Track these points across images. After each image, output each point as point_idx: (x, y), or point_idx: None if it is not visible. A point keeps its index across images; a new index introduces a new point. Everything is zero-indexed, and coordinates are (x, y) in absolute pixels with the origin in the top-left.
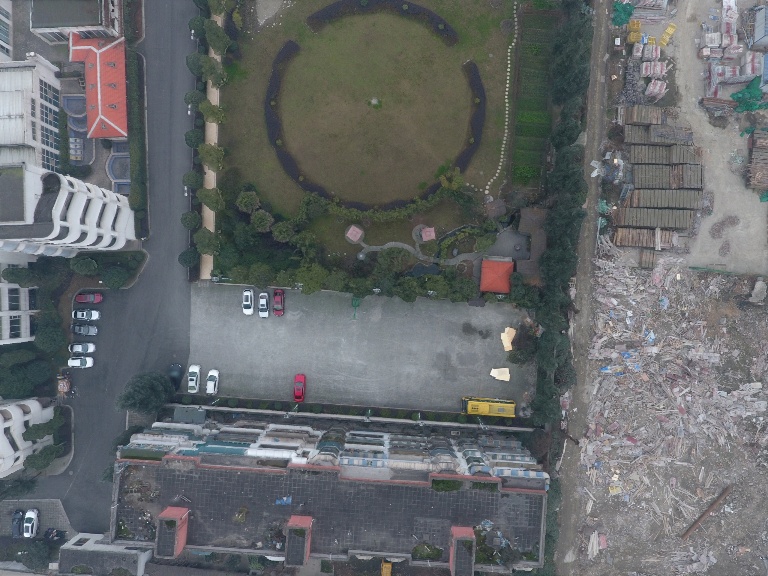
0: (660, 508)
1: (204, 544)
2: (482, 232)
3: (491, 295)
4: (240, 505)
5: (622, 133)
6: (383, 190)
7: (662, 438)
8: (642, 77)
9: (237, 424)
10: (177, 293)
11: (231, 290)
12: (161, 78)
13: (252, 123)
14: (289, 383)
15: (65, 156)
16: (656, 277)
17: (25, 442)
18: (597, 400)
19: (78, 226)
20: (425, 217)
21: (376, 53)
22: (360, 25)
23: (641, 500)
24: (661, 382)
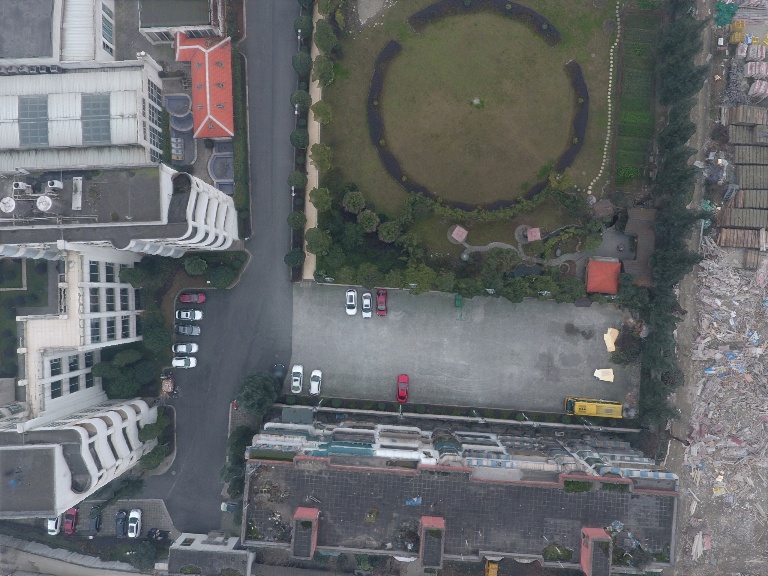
0: (764, 509)
1: (334, 545)
2: (586, 232)
3: (601, 296)
4: (370, 506)
5: (726, 133)
6: (485, 190)
7: (766, 439)
8: (745, 77)
9: (346, 424)
10: (279, 293)
11: (333, 290)
12: (262, 78)
13: (354, 123)
14: (391, 383)
15: (168, 156)
16: (760, 278)
17: (137, 442)
18: (701, 401)
19: (203, 226)
20: (528, 217)
21: (478, 53)
22: (462, 25)
23: (745, 501)
24: (765, 383)
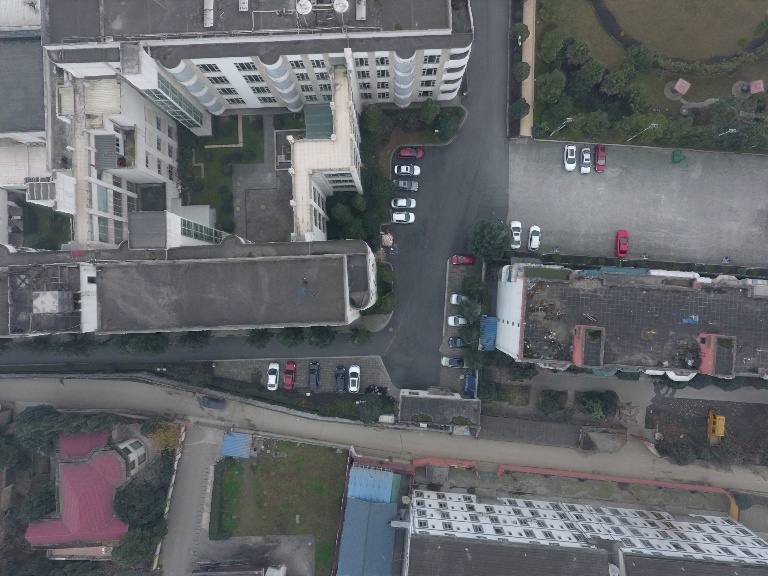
0: None
1: (611, 363)
2: None
3: None
4: (646, 324)
5: None
6: (702, 47)
7: None
8: None
9: None
10: (496, 150)
11: (549, 147)
12: None
13: None
14: (609, 240)
15: None
16: None
17: None
18: None
19: None
20: (745, 73)
21: None
22: None
23: None
24: None
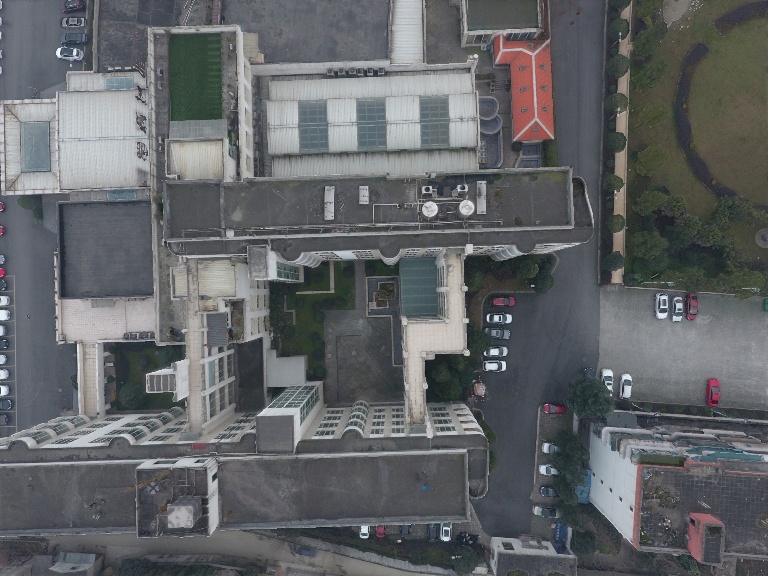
0: None
1: (725, 550)
2: None
3: None
4: (760, 511)
5: None
6: None
7: None
8: None
9: (673, 429)
10: (587, 297)
11: (640, 294)
12: (568, 81)
13: (660, 126)
14: (700, 388)
15: None
16: None
17: None
18: None
19: None
20: None
21: None
22: (767, 28)
23: None
24: None
